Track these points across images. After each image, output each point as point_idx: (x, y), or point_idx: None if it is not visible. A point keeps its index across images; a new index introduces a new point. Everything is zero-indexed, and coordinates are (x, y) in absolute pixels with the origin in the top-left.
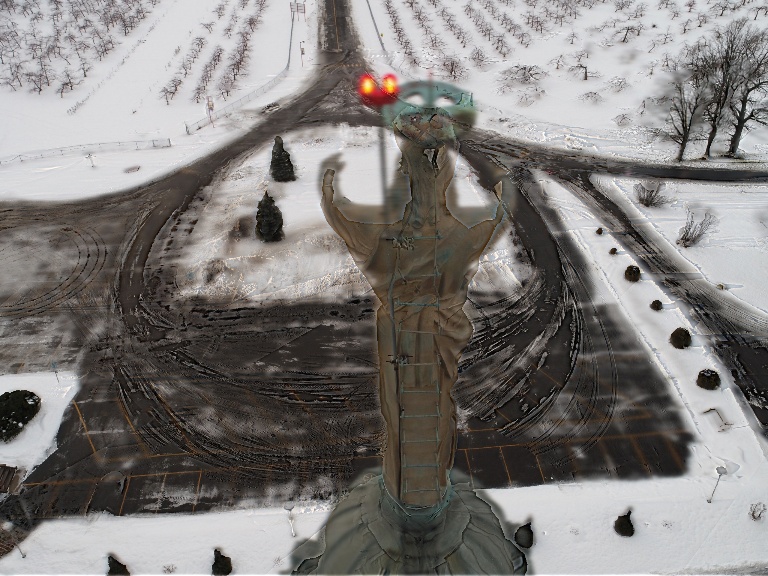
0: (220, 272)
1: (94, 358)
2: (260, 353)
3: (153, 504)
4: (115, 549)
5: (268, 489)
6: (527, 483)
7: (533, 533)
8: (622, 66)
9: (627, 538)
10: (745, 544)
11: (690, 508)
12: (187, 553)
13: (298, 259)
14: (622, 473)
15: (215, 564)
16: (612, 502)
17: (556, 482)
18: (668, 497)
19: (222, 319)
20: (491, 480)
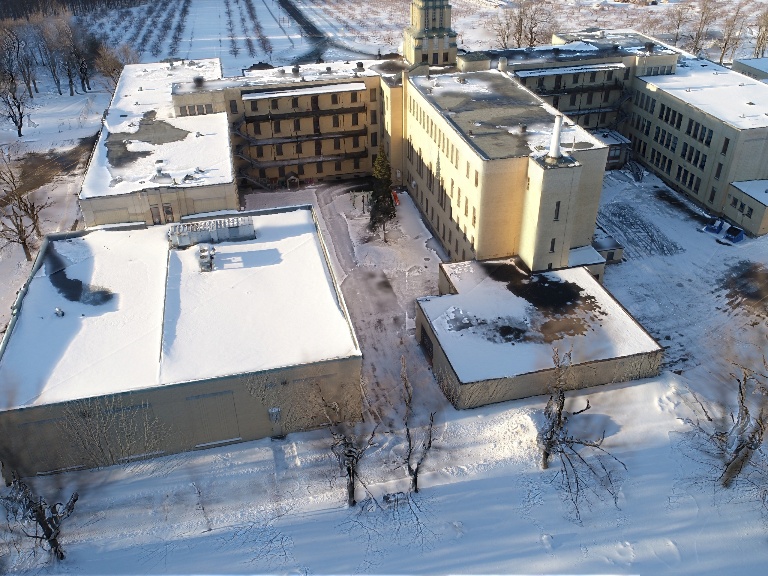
0: None
1: None
2: None
3: None
4: None
5: None
6: None
7: None
8: (481, 37)
9: None
10: None
11: None
12: None
13: None
14: None
15: None
16: None
17: None
18: None
19: None
20: None
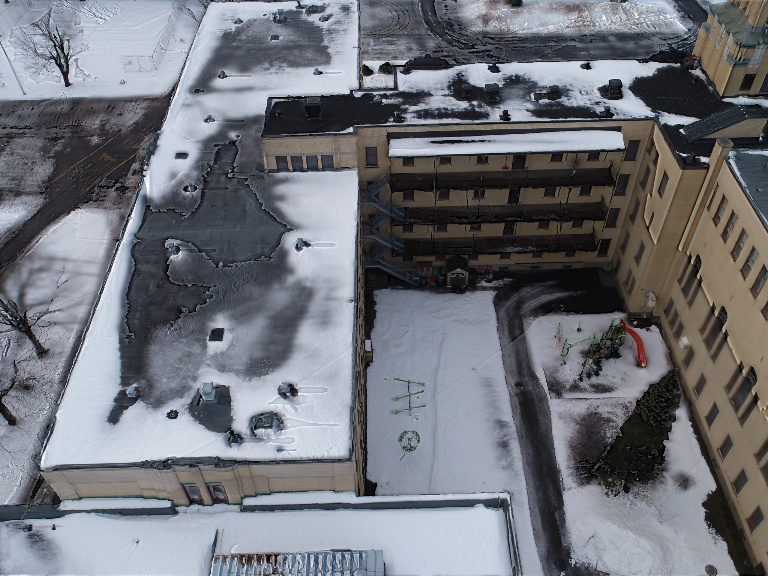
0: (495, 17)
1: (438, 55)
2: (537, 55)
3: None
4: None
5: None
6: None
7: None
8: None
9: None
10: None
11: None
12: None
13: (540, 14)
14: None
15: None
16: None
17: None
18: None
19: (505, 41)
20: None
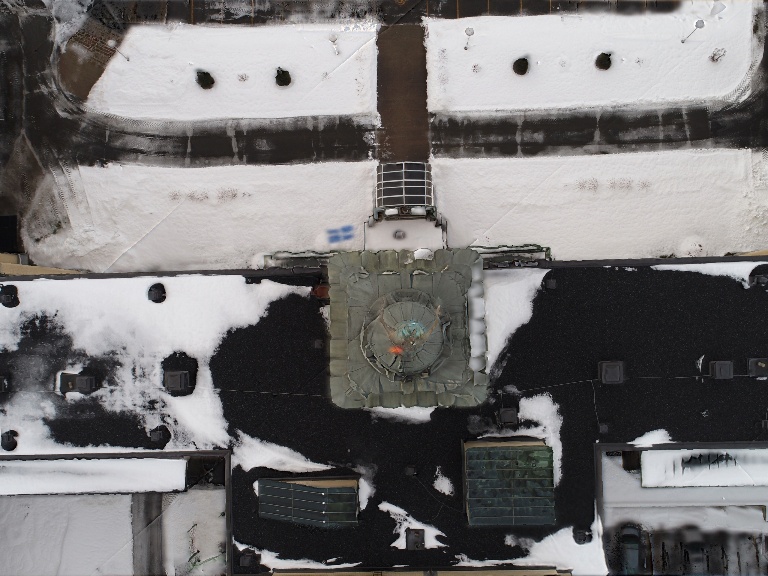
0: None
1: None
2: None
3: (218, 14)
4: (197, 57)
5: (313, 5)
6: (535, 12)
7: (529, 63)
8: None
9: (603, 71)
10: (695, 82)
11: (664, 47)
12: (254, 64)
13: None
14: (621, 6)
15: (278, 78)
16: (602, 37)
17: (561, 12)
18: (650, 35)
19: None
20: (505, 7)
